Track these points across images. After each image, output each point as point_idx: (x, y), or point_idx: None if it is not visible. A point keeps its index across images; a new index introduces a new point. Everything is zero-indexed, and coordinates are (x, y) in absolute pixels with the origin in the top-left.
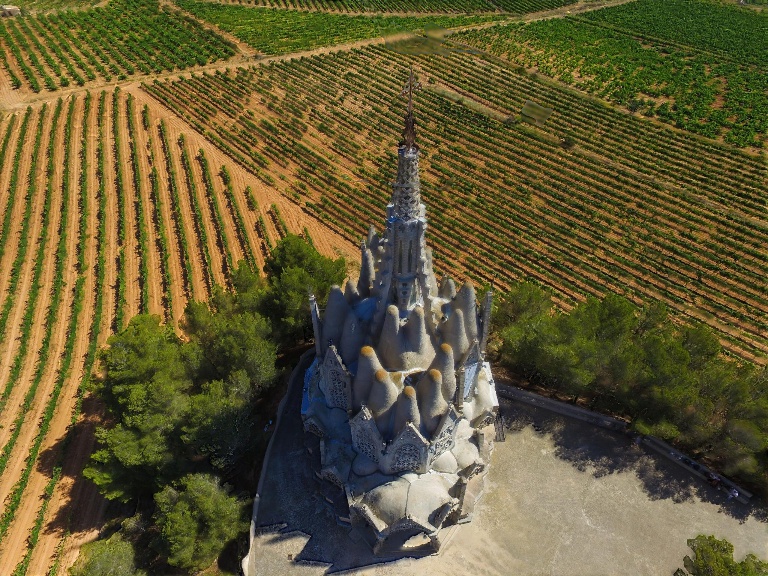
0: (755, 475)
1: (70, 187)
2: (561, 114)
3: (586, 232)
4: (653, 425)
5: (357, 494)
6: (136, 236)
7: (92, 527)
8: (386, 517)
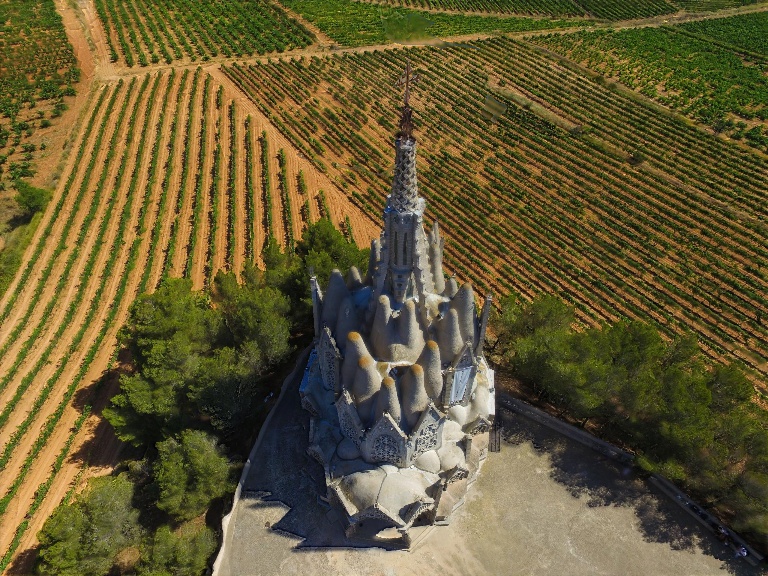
0: (767, 536)
1: (143, 155)
2: (635, 128)
3: (637, 254)
4: (659, 463)
5: (336, 476)
6: (192, 206)
7: (108, 464)
8: (358, 503)
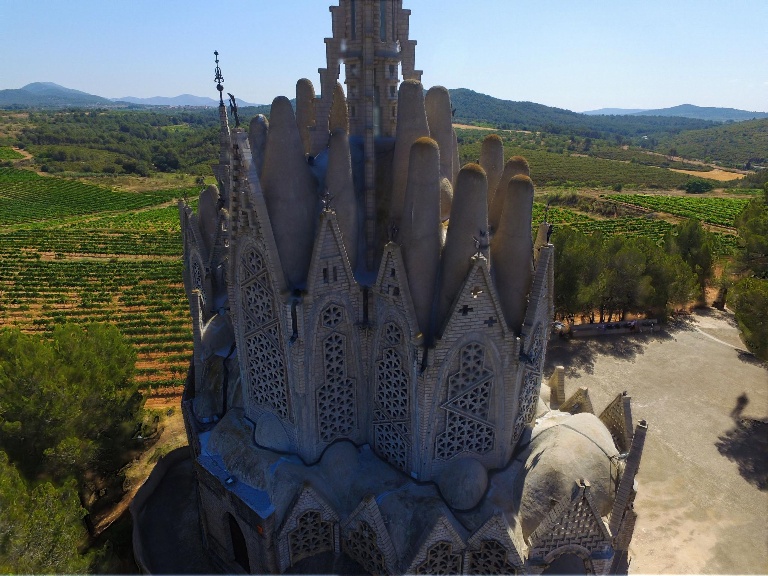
0: (650, 296)
1: None
2: None
3: None
4: None
5: None
6: None
7: None
8: None
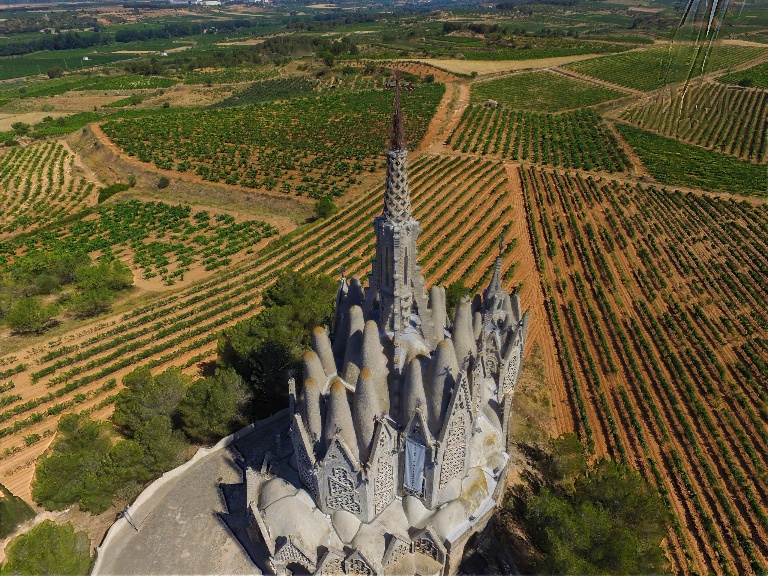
0: None
1: None
2: None
3: None
4: None
5: (272, 471)
6: None
7: None
8: (260, 501)
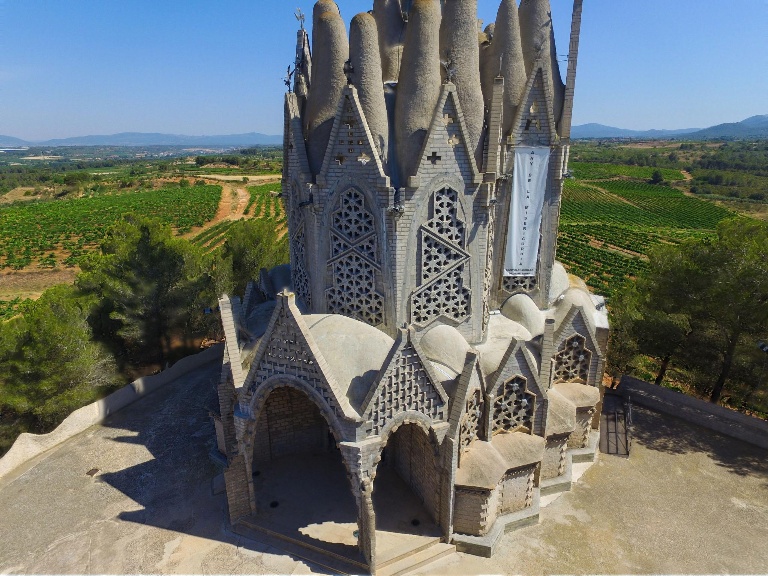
0: None
1: None
2: None
3: None
4: None
5: (249, 349)
6: None
7: None
8: None
